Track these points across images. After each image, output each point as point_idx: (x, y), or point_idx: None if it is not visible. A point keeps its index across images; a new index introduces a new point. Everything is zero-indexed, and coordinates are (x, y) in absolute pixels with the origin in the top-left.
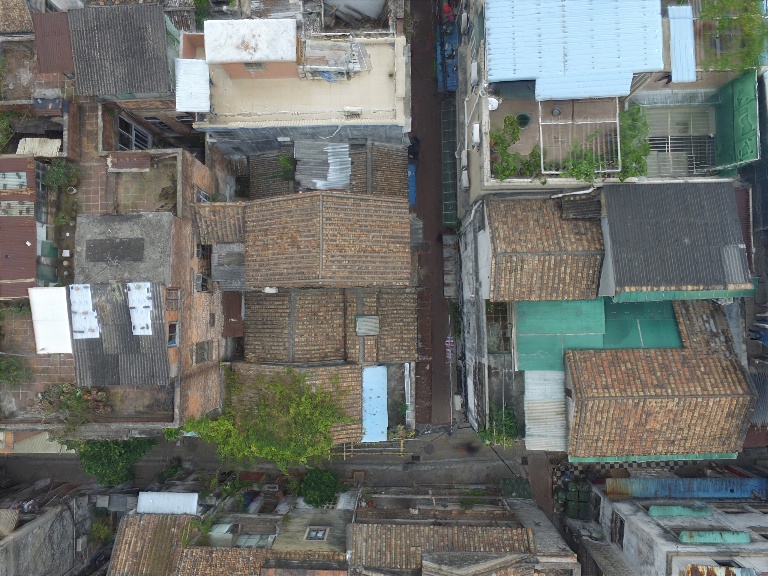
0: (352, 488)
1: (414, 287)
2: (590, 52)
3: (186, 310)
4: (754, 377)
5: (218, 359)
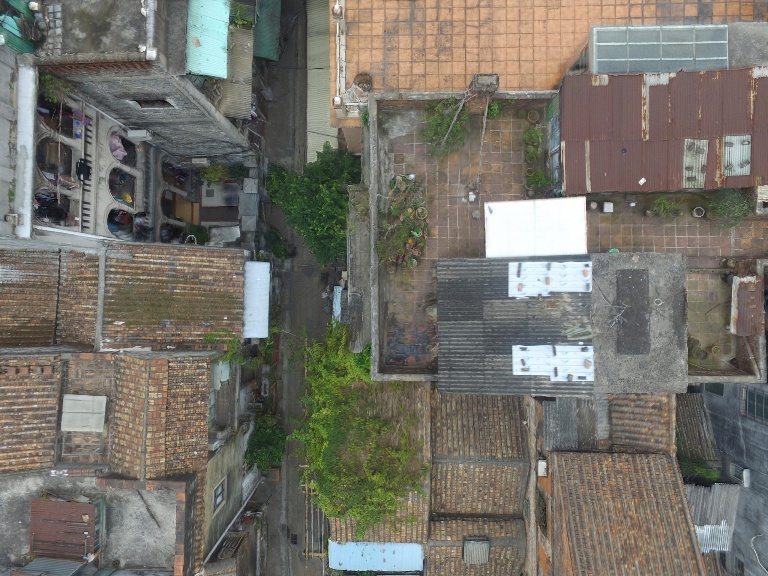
0: (261, 470)
1: None
2: None
3: None
4: None
5: None
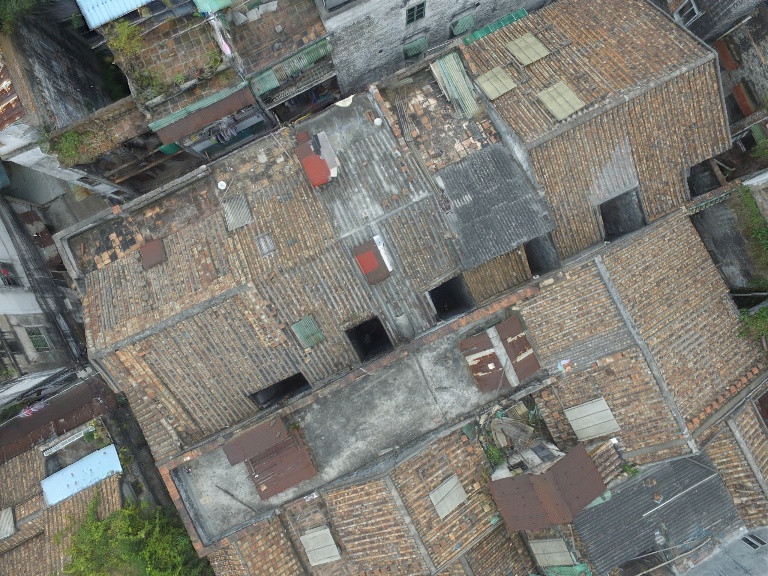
0: None
1: None
2: None
3: None
4: None
5: None
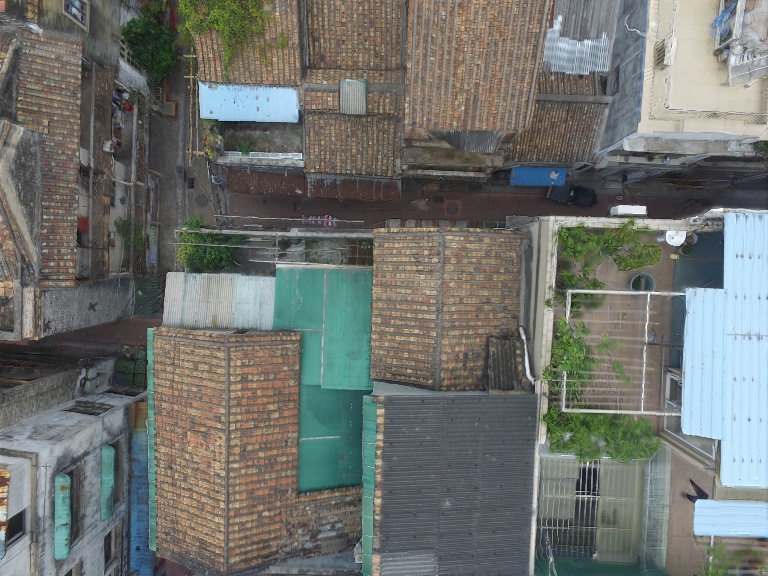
0: None
1: (402, 172)
2: (762, 376)
3: None
4: None
5: None
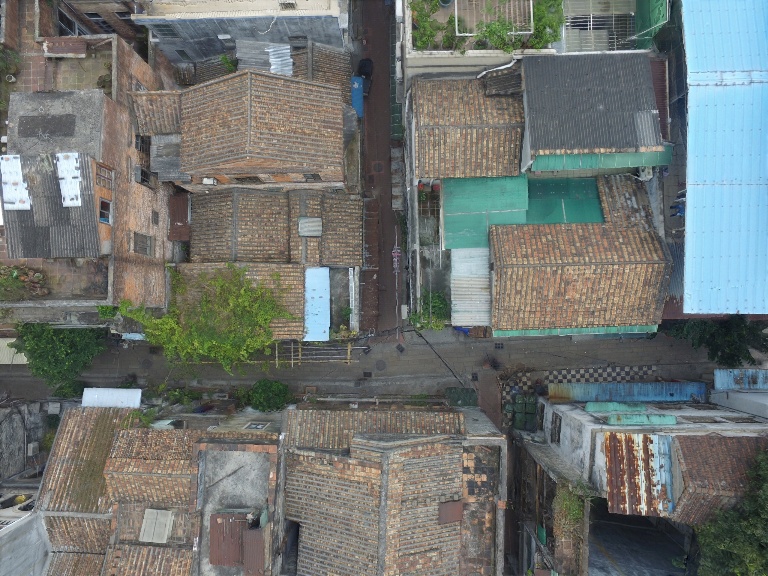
0: (303, 401)
1: (359, 194)
2: None
3: (122, 194)
4: (671, 247)
5: (163, 260)
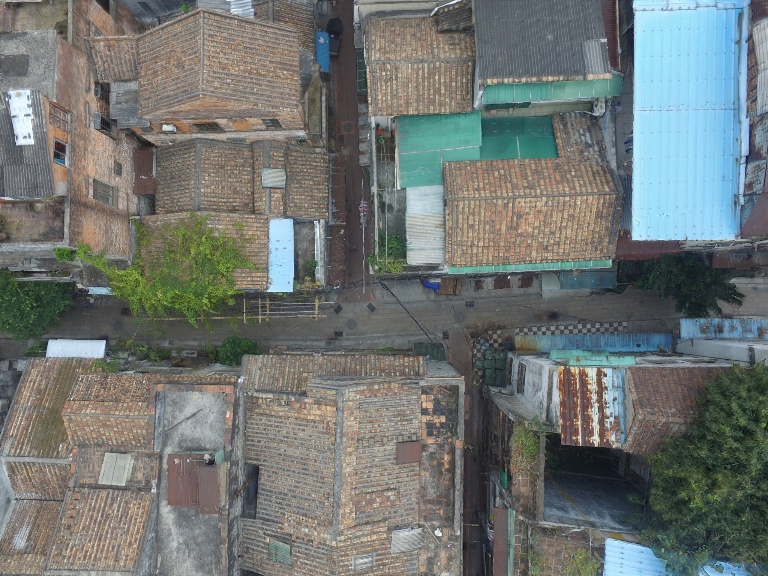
0: None
1: (325, 148)
2: None
3: (79, 138)
4: (623, 180)
5: (127, 212)
